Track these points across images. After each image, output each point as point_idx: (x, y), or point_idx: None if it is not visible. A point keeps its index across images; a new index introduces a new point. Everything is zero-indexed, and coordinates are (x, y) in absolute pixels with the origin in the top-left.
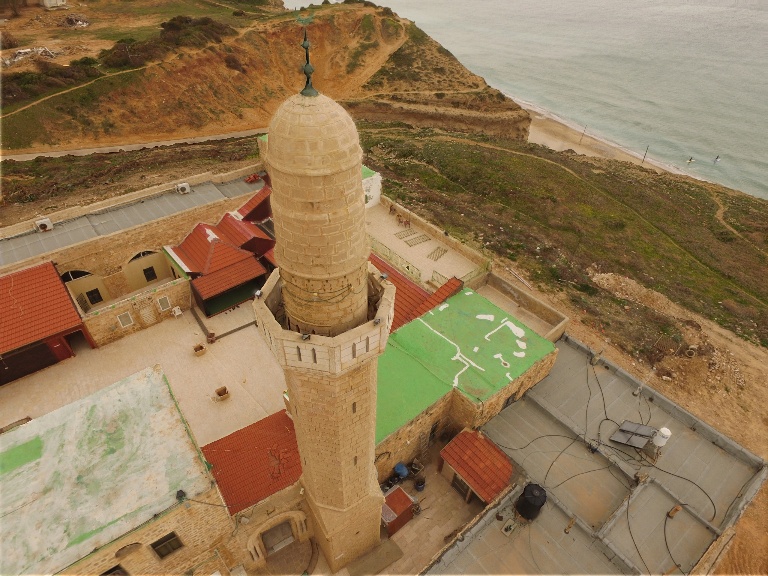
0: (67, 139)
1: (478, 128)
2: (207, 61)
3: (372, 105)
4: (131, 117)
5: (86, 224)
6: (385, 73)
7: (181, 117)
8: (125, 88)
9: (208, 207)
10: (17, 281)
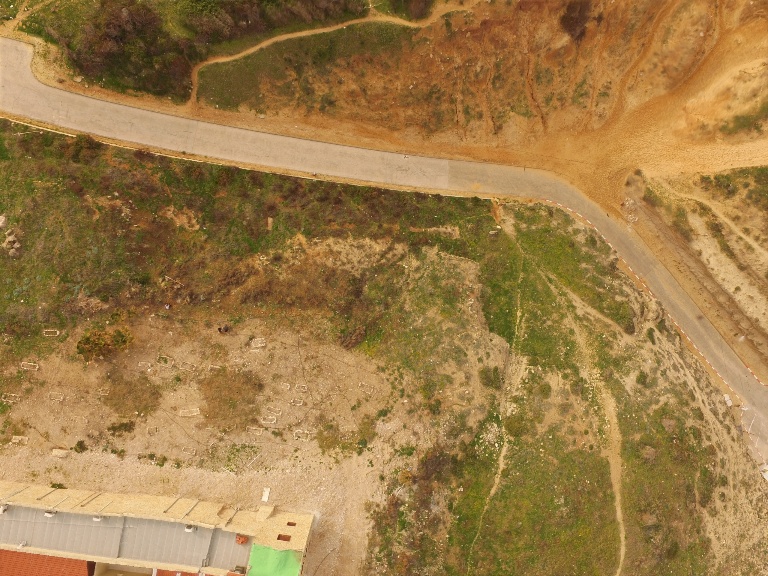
0: (277, 108)
1: (761, 338)
2: (538, 2)
3: (670, 222)
4: (360, 96)
5: (121, 525)
6: (763, 179)
7: (418, 114)
8: (375, 55)
9: (183, 571)
10: (68, 560)
